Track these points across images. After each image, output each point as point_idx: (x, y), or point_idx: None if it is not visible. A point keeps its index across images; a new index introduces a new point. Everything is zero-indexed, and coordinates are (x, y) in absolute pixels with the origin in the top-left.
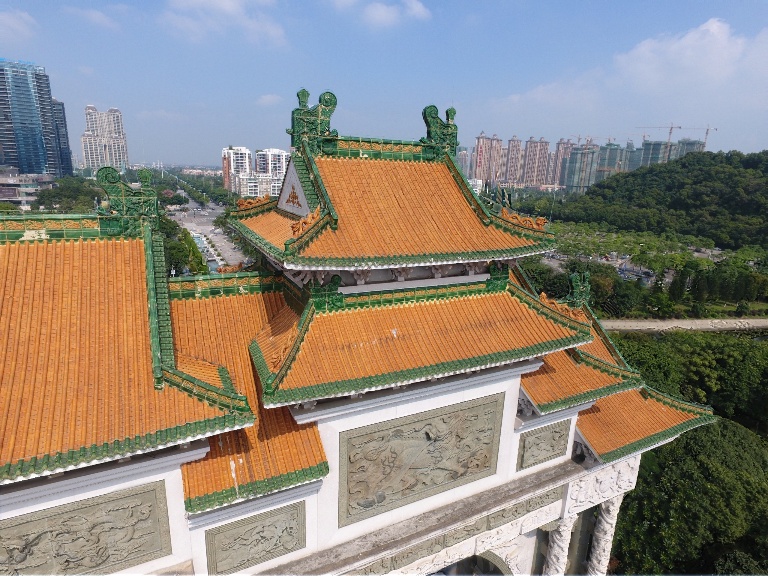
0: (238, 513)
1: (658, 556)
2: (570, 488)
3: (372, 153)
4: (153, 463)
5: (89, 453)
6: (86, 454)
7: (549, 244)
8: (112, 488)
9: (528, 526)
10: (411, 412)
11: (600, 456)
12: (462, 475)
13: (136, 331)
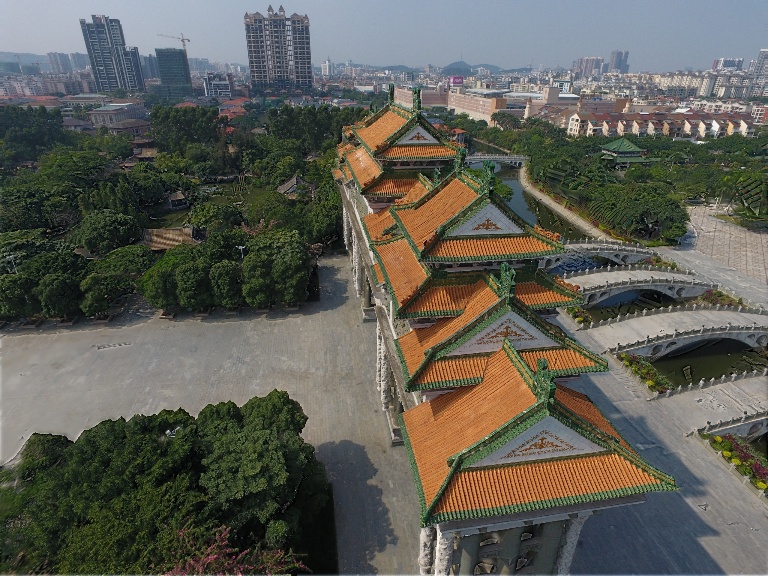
0: None
1: None
2: None
3: None
4: None
5: None
6: None
7: None
8: None
9: None
10: None
11: None
12: None
13: None
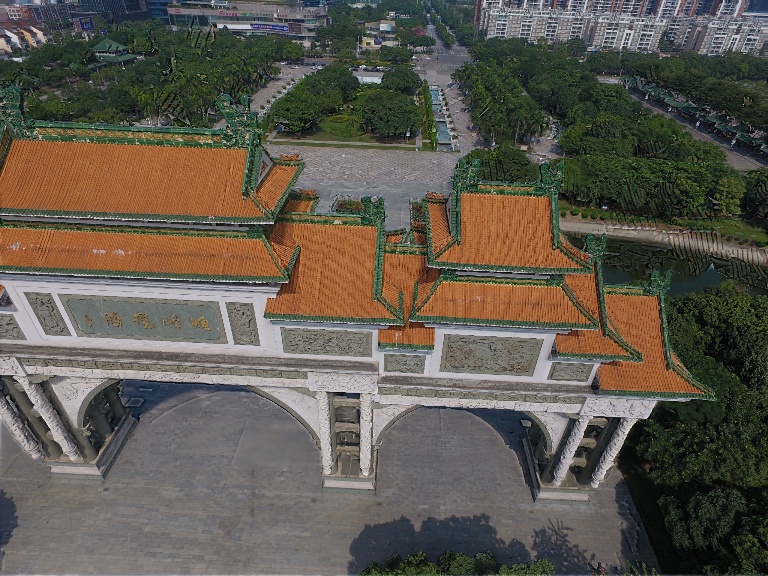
0: (397, 352)
1: (681, 472)
2: (587, 400)
3: (499, 191)
4: (369, 326)
5: (351, 320)
6: (350, 320)
7: (588, 270)
8: (355, 330)
9: (552, 409)
10: (483, 335)
11: (601, 390)
12: (510, 371)
13: (369, 273)
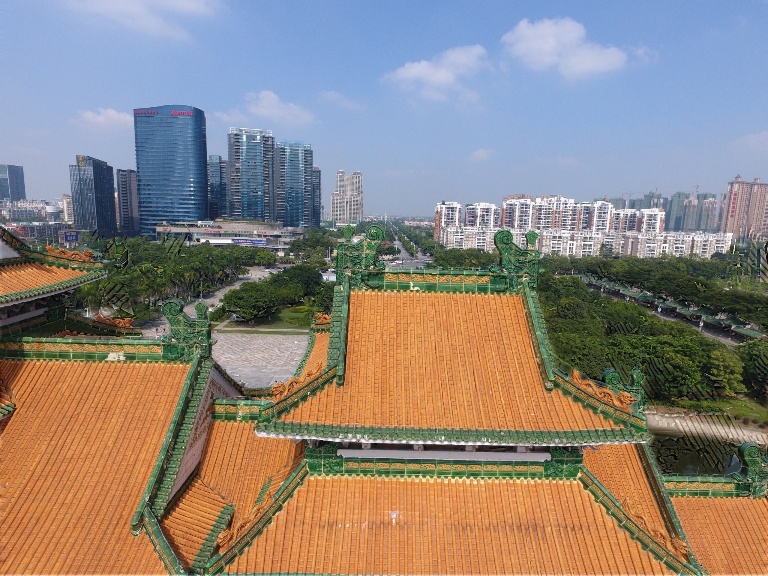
0: None
1: None
2: None
3: (425, 285)
4: None
5: None
6: None
7: (637, 432)
8: None
9: None
10: None
11: None
12: None
13: (150, 462)
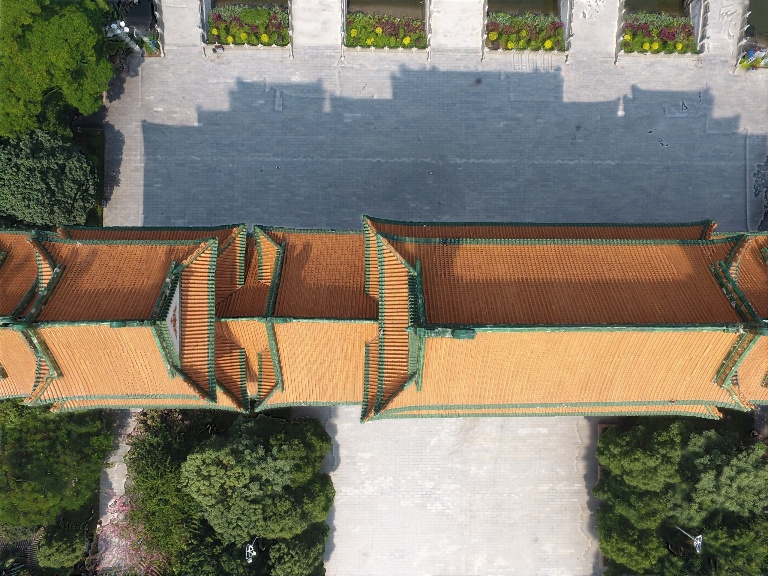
0: None
1: None
2: None
3: None
4: None
5: None
6: None
7: None
8: None
9: None
10: None
11: None
12: None
13: None
